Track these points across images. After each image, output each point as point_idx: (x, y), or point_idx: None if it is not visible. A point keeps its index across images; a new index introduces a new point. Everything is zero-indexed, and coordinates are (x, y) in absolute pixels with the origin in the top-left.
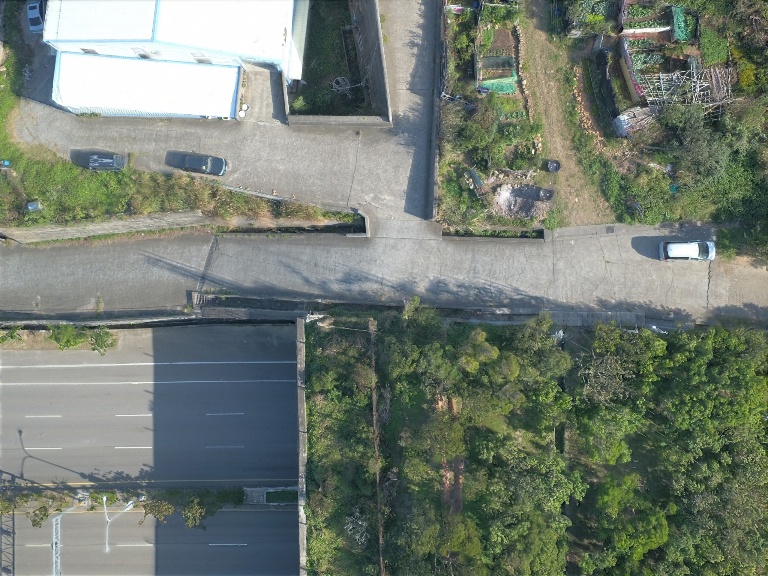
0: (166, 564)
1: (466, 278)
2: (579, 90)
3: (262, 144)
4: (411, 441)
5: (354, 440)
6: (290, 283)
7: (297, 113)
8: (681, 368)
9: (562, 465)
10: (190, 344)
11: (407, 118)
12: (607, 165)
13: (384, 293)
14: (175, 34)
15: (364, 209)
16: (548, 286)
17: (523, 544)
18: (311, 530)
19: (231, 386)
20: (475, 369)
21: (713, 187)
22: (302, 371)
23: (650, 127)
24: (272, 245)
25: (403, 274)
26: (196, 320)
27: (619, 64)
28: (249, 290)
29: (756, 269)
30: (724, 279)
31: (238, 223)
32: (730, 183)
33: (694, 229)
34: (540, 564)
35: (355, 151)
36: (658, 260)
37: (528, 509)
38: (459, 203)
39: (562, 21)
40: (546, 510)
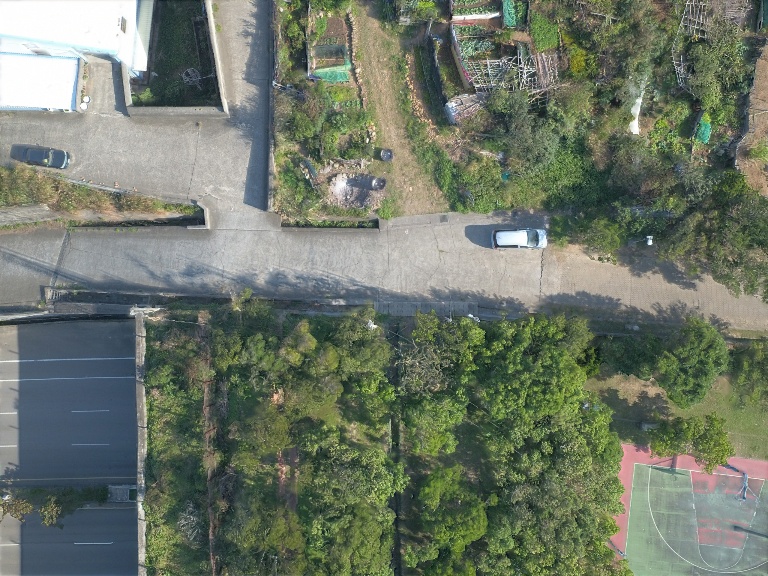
0: (31, 564)
1: (304, 269)
2: (411, 78)
3: (105, 136)
4: (238, 434)
5: (189, 434)
6: (136, 277)
7: (143, 105)
8: (499, 357)
9: (383, 457)
10: (55, 341)
11: (244, 108)
12: (439, 153)
13: (225, 285)
14: (4, 25)
15: (204, 201)
16: (383, 276)
17: (343, 537)
18: (150, 526)
19: (96, 383)
20: (300, 360)
21: (543, 174)
22: (141, 365)
23: (480, 114)
24: (120, 239)
25: (243, 266)
26: (63, 316)
27: (451, 51)
28: (99, 284)
29: (588, 257)
30: (556, 267)
31: (88, 217)
32: (560, 170)
33: (527, 217)
34: (360, 557)
35: (195, 142)
36: (491, 249)
37: (352, 502)
38: (295, 193)
39: (393, 8)
40: (369, 502)
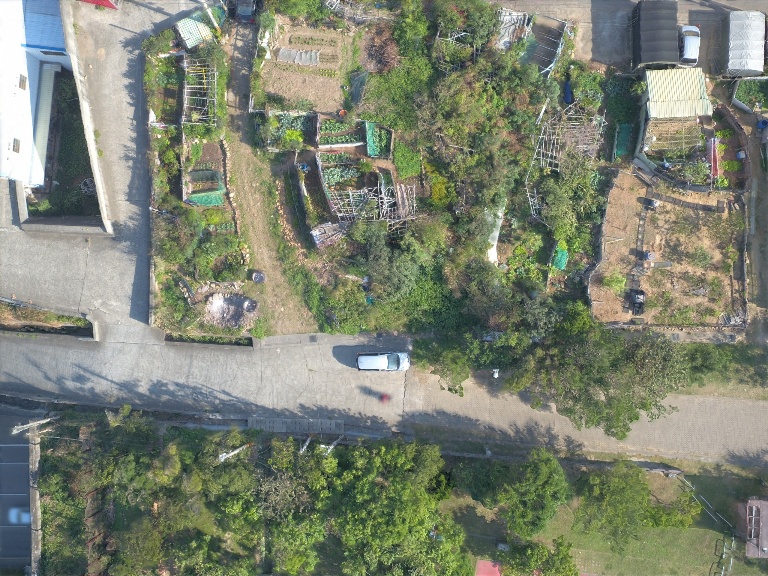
0: None
1: (185, 383)
2: (281, 203)
3: (3, 250)
4: (115, 547)
5: (76, 540)
6: (36, 381)
7: (42, 217)
8: (350, 485)
9: (243, 575)
10: None
11: (128, 228)
12: (308, 277)
13: (113, 395)
14: None
15: (93, 314)
16: (256, 393)
17: None
18: None
19: (14, 468)
20: (169, 480)
21: (405, 299)
22: (34, 471)
23: (344, 241)
24: (22, 344)
25: (130, 377)
26: None
27: (319, 178)
28: (3, 386)
29: None
30: (418, 388)
31: None
32: (421, 295)
33: (391, 339)
34: None
35: (85, 258)
36: (357, 369)
37: None
38: (174, 312)
39: None
40: None
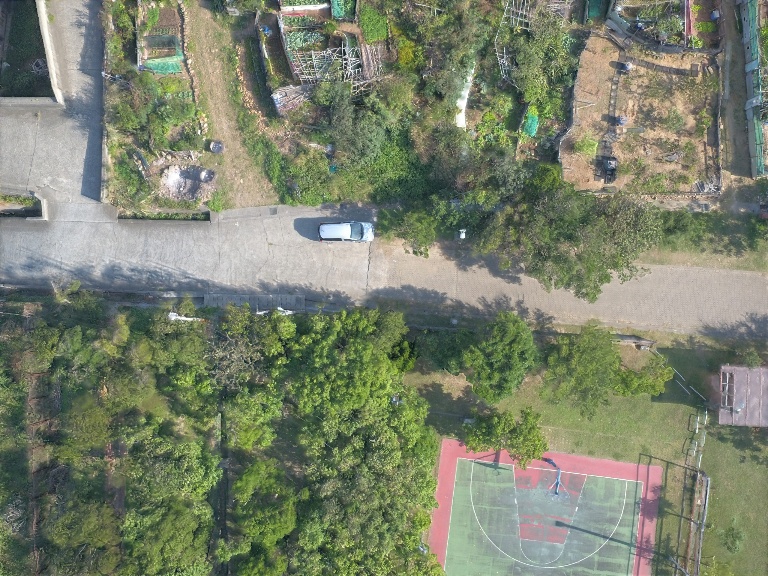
0: None
1: (139, 261)
2: (241, 69)
3: None
4: (60, 426)
5: (20, 426)
6: None
7: None
8: (309, 350)
9: (196, 449)
10: None
11: (80, 99)
12: (268, 145)
13: (62, 277)
14: None
15: (43, 192)
16: (214, 269)
17: (155, 530)
18: None
19: None
20: (119, 353)
21: (369, 167)
22: None
23: (306, 106)
24: None
25: (80, 258)
26: None
27: (280, 42)
28: None
29: None
30: (383, 260)
31: None
32: (386, 163)
33: (355, 210)
34: (171, 550)
35: (34, 133)
36: (319, 242)
37: (169, 494)
38: (127, 185)
39: None
40: (183, 495)
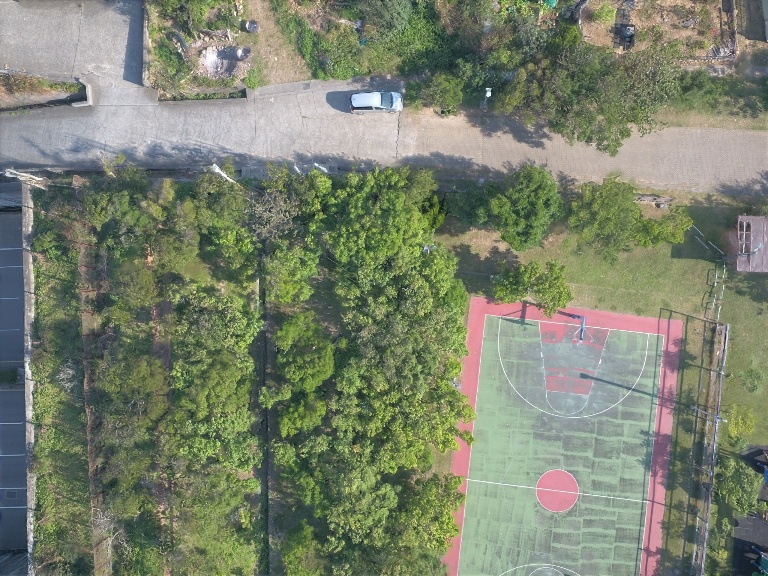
0: None
1: (179, 140)
2: None
3: None
4: (109, 289)
5: (69, 295)
6: (29, 157)
7: None
8: (344, 204)
9: (238, 302)
10: None
11: None
12: (301, 23)
13: None
14: None
15: (87, 78)
16: (250, 143)
17: (201, 378)
18: (37, 386)
19: (7, 272)
20: (163, 216)
21: (398, 39)
22: (27, 234)
23: None
24: (15, 122)
25: (123, 140)
26: None
27: None
28: None
29: (442, 119)
30: (412, 129)
31: None
32: (414, 35)
33: (384, 82)
34: (216, 396)
35: (78, 23)
36: (350, 113)
37: (212, 348)
38: (168, 66)
39: None
40: (226, 347)
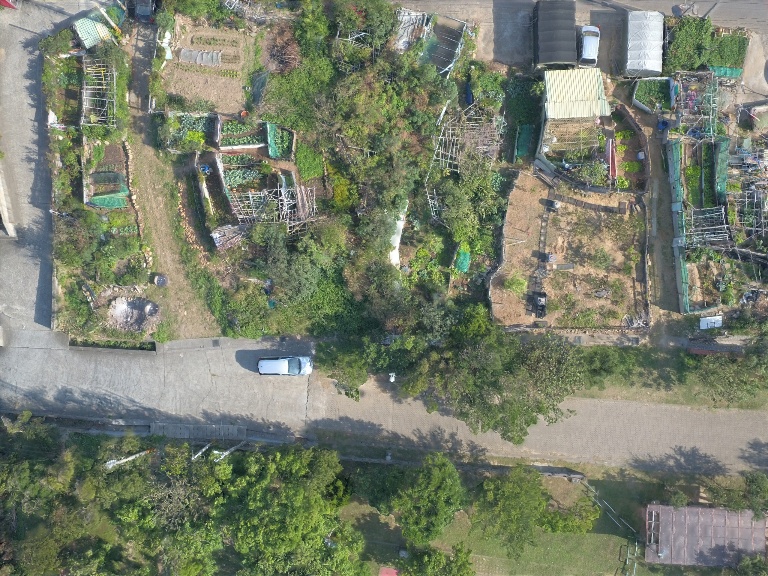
0: None
1: (89, 388)
2: (183, 205)
3: None
4: (11, 556)
5: None
6: None
7: None
8: (244, 491)
9: None
10: None
11: (31, 231)
12: (210, 280)
13: (17, 401)
14: None
15: None
16: (159, 398)
17: None
18: None
19: None
20: (65, 487)
21: (306, 303)
22: None
23: (245, 244)
24: None
25: (34, 383)
26: None
27: None
28: None
29: None
30: (321, 393)
31: None
32: (323, 298)
33: (294, 343)
34: None
35: None
36: None
37: None
38: (77, 316)
39: None
40: None
